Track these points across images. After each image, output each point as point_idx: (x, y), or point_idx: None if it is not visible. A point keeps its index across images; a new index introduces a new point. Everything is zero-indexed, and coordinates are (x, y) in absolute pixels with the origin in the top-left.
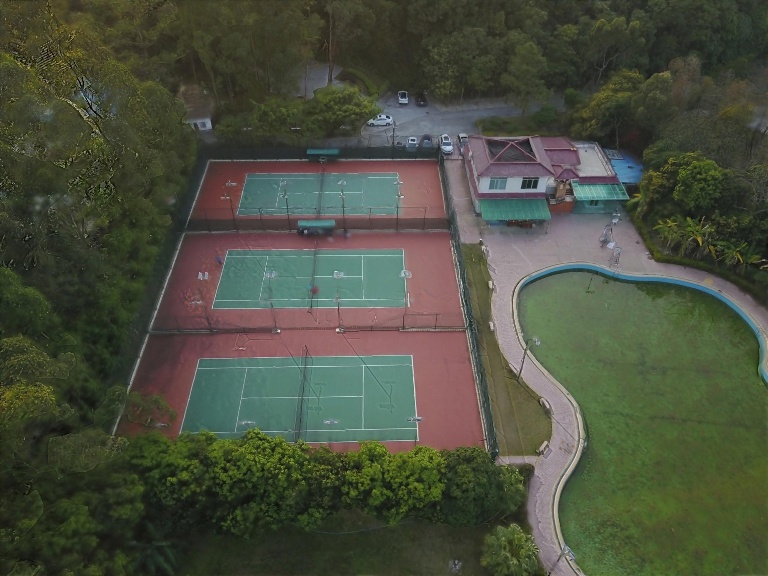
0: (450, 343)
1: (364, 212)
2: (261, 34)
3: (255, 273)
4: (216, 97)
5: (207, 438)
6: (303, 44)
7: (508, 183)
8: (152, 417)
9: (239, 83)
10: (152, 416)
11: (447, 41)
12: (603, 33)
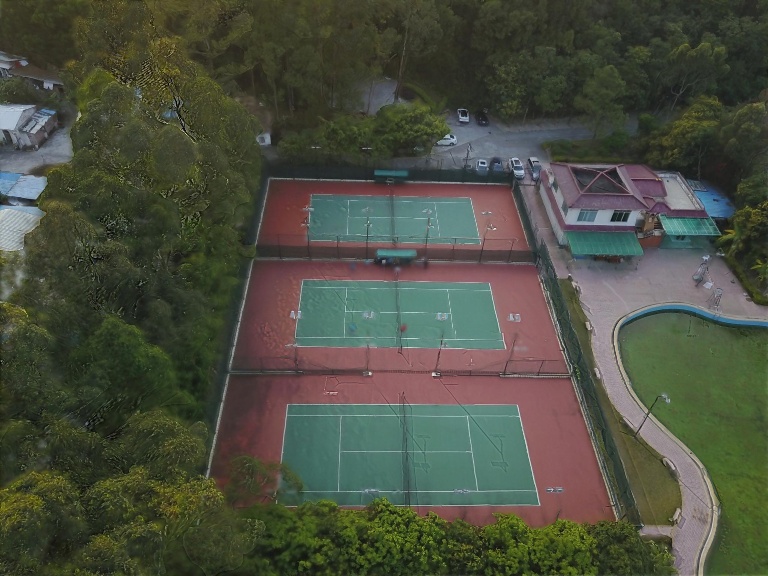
0: (556, 392)
1: (442, 241)
2: (330, 47)
3: (335, 307)
4: (273, 110)
5: (330, 509)
6: (372, 58)
7: (598, 215)
8: (278, 489)
9: (304, 97)
10: (278, 488)
11: (514, 59)
12: (687, 58)
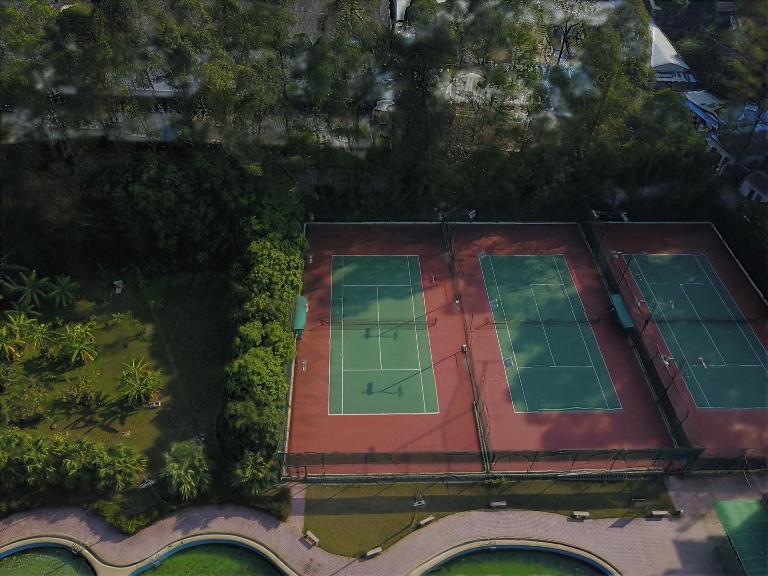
0: None
1: None
2: None
3: (534, 278)
4: None
5: None
6: None
7: None
8: None
9: None
10: None
11: None
12: None
